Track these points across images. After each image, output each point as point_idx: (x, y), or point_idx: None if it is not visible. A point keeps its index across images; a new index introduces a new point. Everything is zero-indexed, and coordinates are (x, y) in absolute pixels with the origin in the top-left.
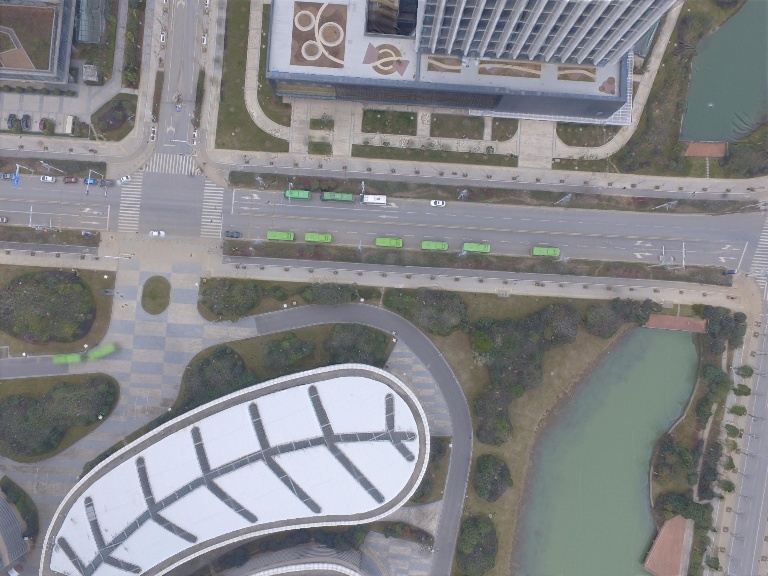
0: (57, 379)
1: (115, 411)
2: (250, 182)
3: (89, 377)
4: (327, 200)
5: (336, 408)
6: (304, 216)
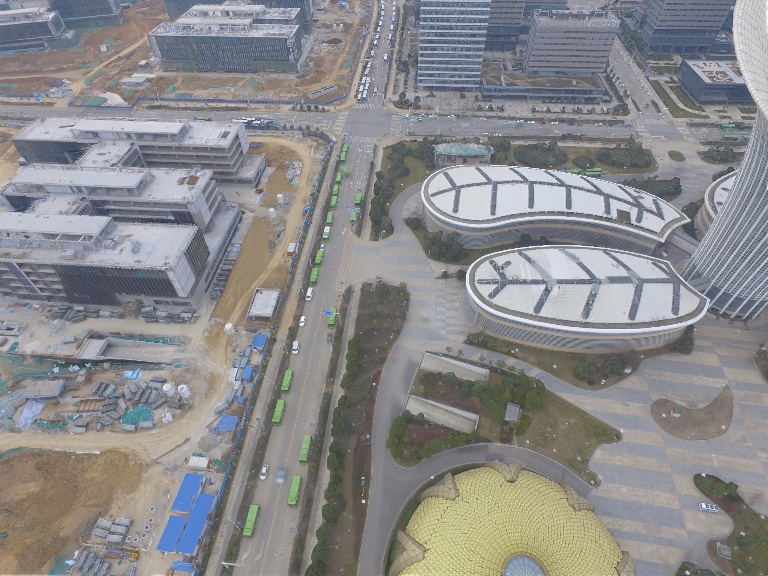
0: (642, 181)
1: (683, 192)
2: (699, 125)
3: None
4: (744, 128)
5: None
6: None
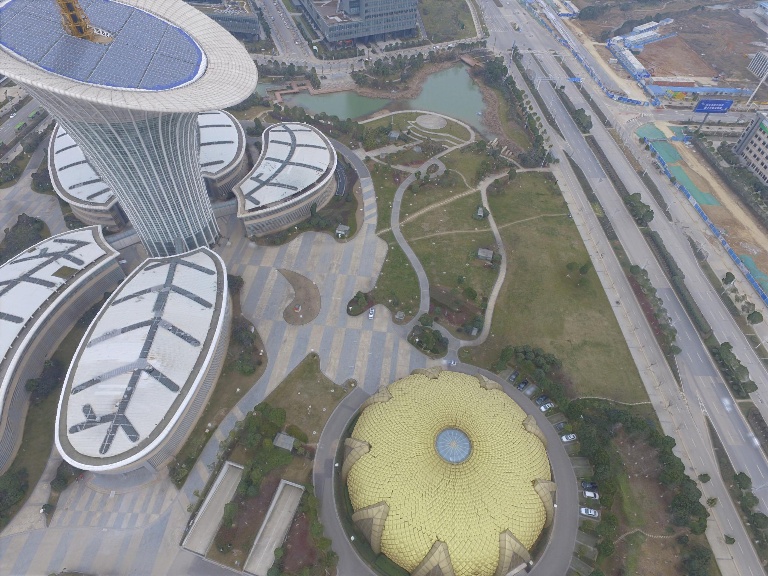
0: (1, 245)
1: None
2: None
3: (11, 231)
4: None
5: None
6: None
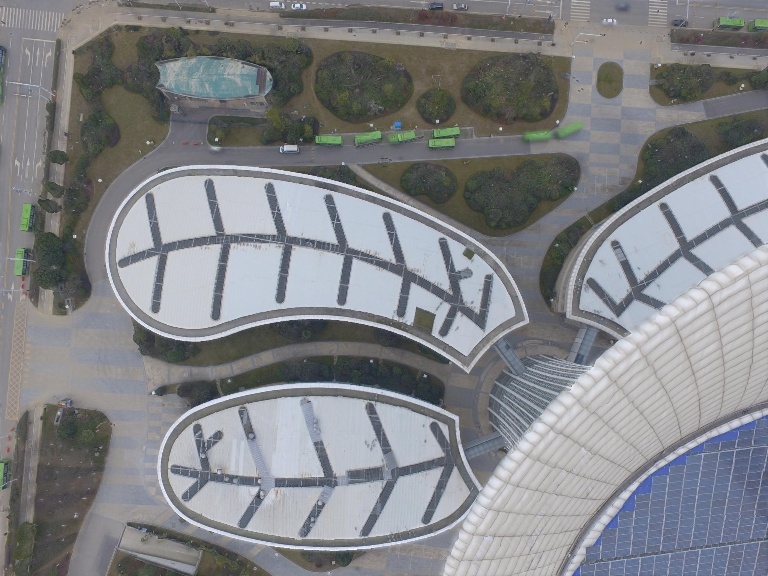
0: (521, 158)
1: (577, 188)
2: None
3: (551, 156)
4: None
5: None
6: (745, 7)
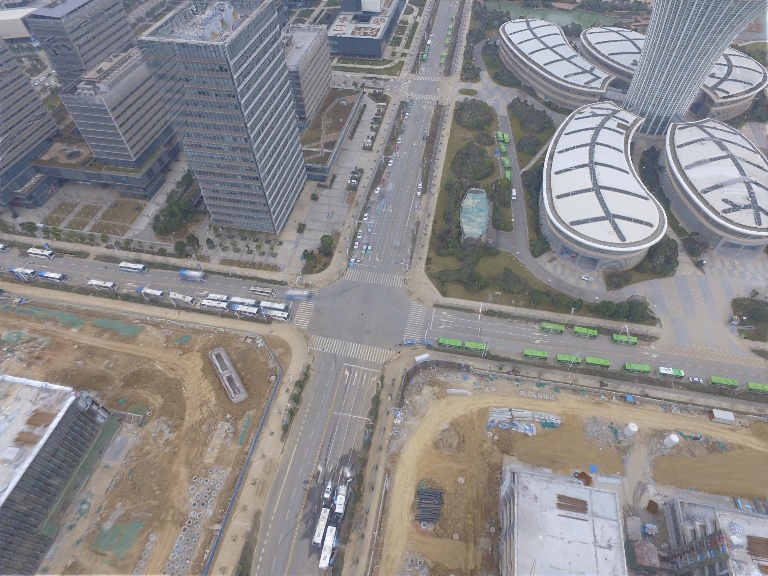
0: None
1: None
2: (417, 69)
3: None
4: None
5: (517, 29)
6: None
